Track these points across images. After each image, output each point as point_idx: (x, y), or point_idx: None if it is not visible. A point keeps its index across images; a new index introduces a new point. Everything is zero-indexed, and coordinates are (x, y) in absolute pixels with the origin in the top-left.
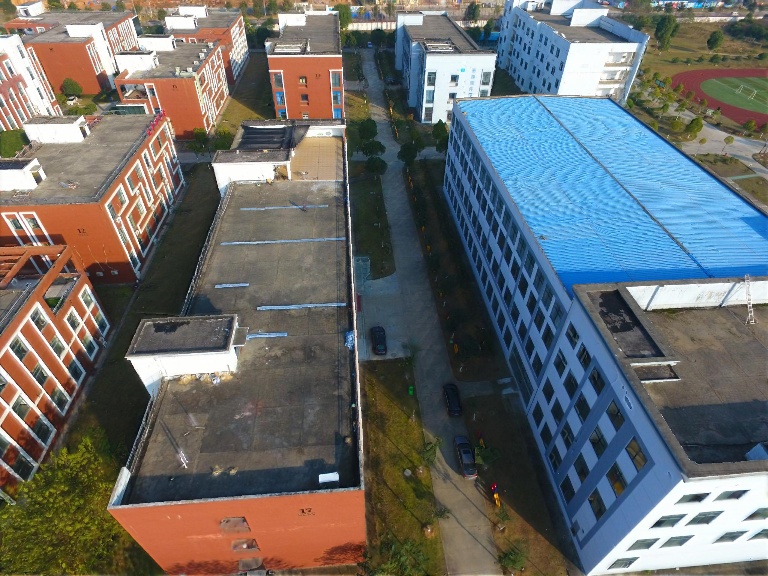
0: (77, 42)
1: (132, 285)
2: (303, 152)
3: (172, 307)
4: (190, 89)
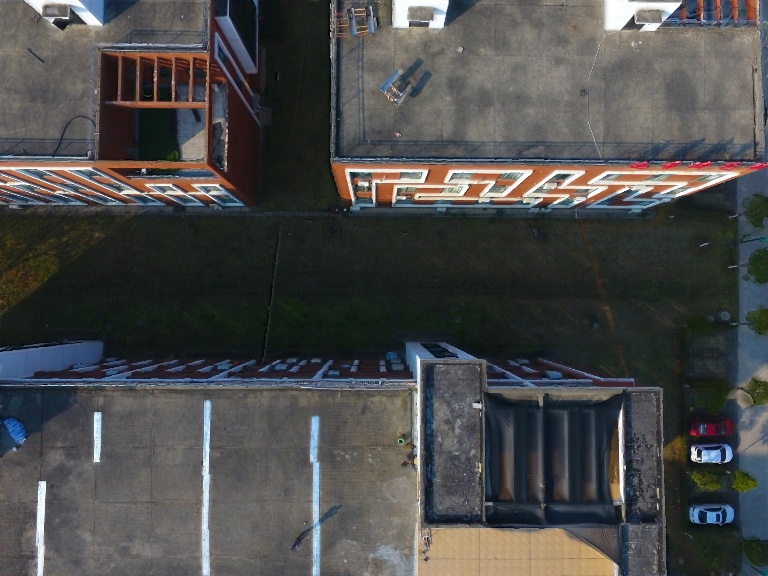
0: None
1: (339, 204)
2: None
3: (289, 273)
4: None
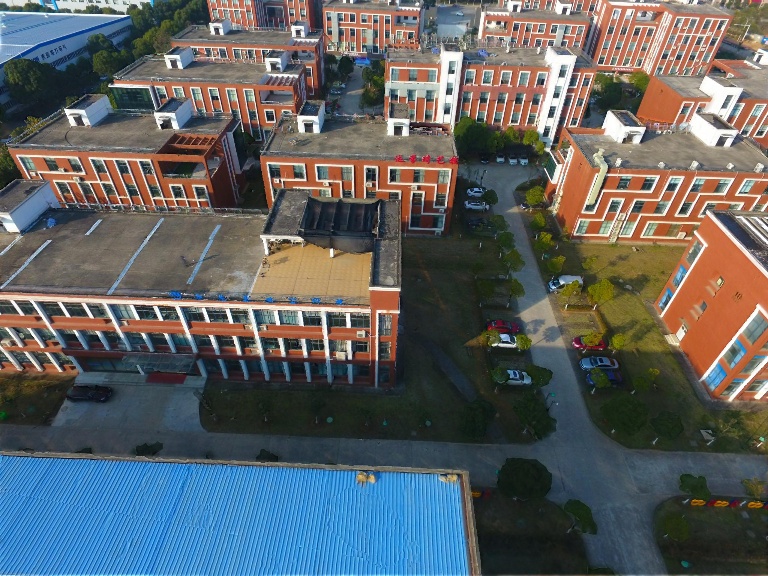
0: (683, 94)
1: None
2: (344, 265)
3: None
4: (585, 178)
